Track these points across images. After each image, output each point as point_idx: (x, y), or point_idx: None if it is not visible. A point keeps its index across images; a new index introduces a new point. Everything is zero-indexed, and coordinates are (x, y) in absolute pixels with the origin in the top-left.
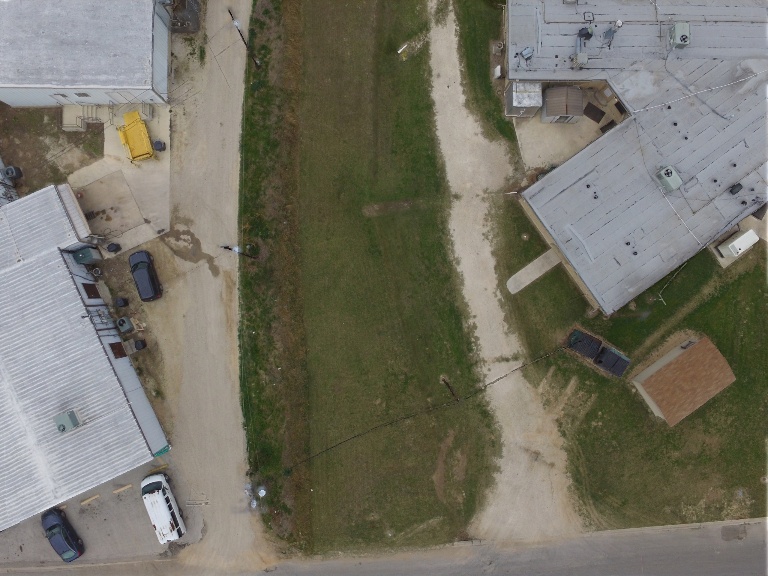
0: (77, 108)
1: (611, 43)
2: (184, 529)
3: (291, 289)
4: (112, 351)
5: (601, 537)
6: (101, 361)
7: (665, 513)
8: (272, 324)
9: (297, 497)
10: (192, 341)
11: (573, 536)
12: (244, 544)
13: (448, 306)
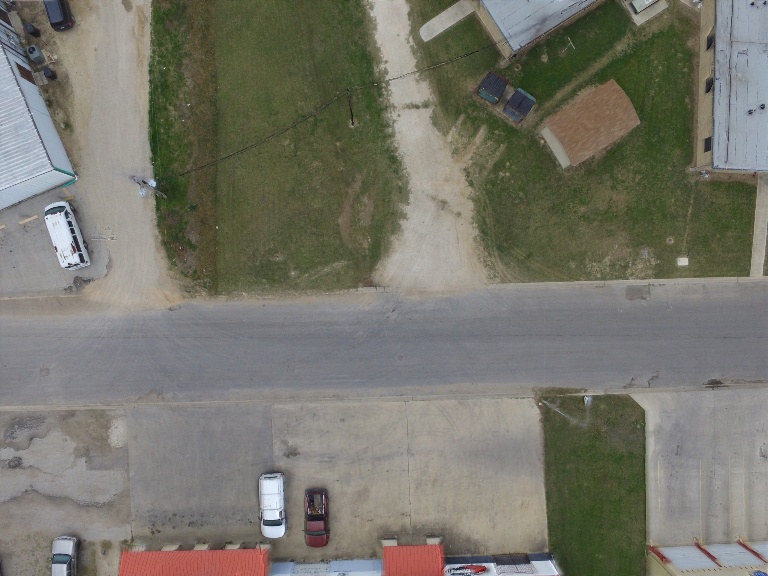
0: None
1: None
2: (88, 260)
3: (202, 23)
4: (18, 68)
5: (505, 290)
6: (4, 70)
7: (569, 268)
8: (183, 61)
9: (202, 233)
10: (103, 75)
11: (477, 287)
12: (149, 281)
13: (360, 50)
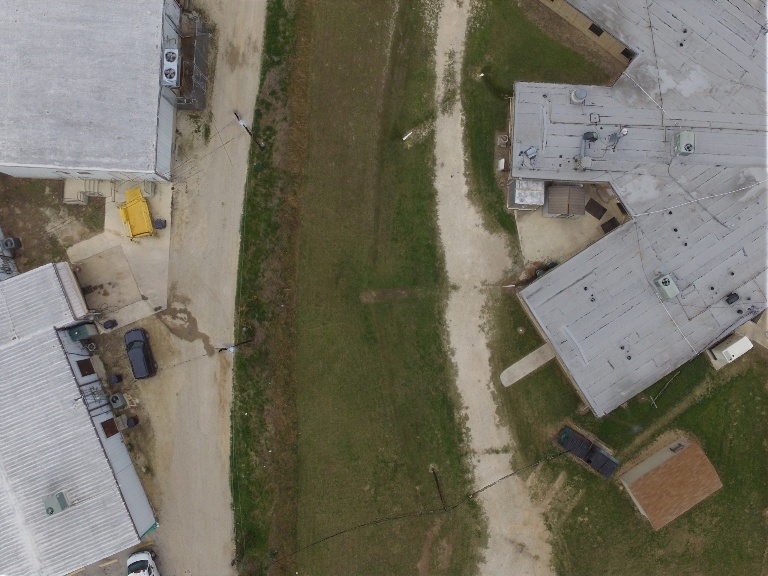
0: (79, 182)
1: (616, 146)
2: None
3: (285, 373)
4: (104, 431)
5: None
6: (92, 443)
7: None
8: (265, 406)
9: None
10: (184, 419)
11: None
12: None
13: (441, 396)
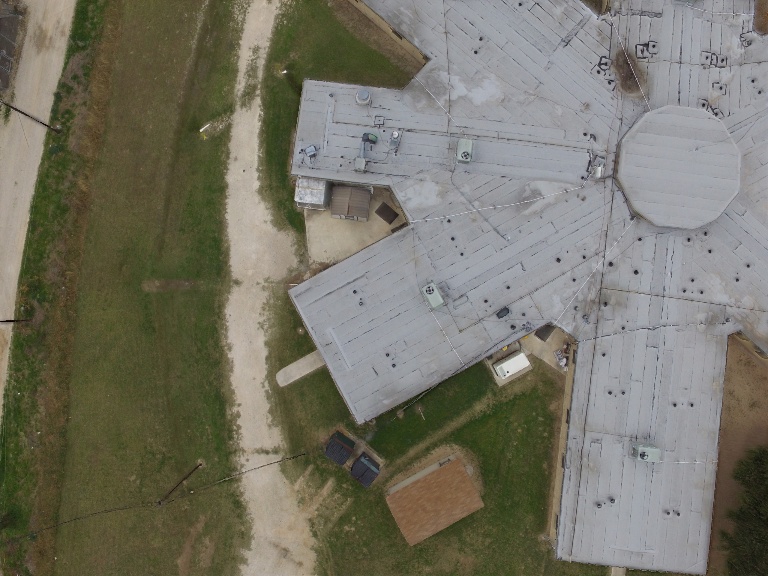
0: None
1: (398, 149)
2: None
3: (58, 356)
4: None
5: None
6: None
7: None
8: (38, 387)
9: (39, 564)
10: None
11: None
12: None
13: (214, 391)
